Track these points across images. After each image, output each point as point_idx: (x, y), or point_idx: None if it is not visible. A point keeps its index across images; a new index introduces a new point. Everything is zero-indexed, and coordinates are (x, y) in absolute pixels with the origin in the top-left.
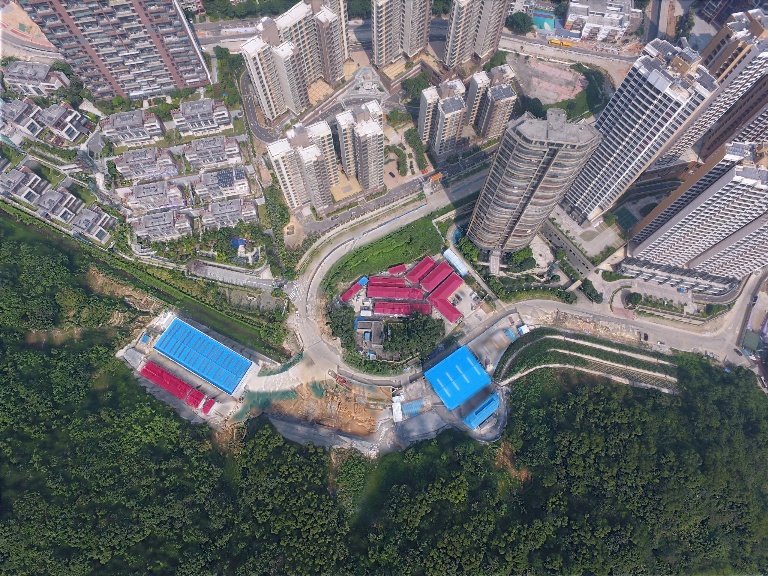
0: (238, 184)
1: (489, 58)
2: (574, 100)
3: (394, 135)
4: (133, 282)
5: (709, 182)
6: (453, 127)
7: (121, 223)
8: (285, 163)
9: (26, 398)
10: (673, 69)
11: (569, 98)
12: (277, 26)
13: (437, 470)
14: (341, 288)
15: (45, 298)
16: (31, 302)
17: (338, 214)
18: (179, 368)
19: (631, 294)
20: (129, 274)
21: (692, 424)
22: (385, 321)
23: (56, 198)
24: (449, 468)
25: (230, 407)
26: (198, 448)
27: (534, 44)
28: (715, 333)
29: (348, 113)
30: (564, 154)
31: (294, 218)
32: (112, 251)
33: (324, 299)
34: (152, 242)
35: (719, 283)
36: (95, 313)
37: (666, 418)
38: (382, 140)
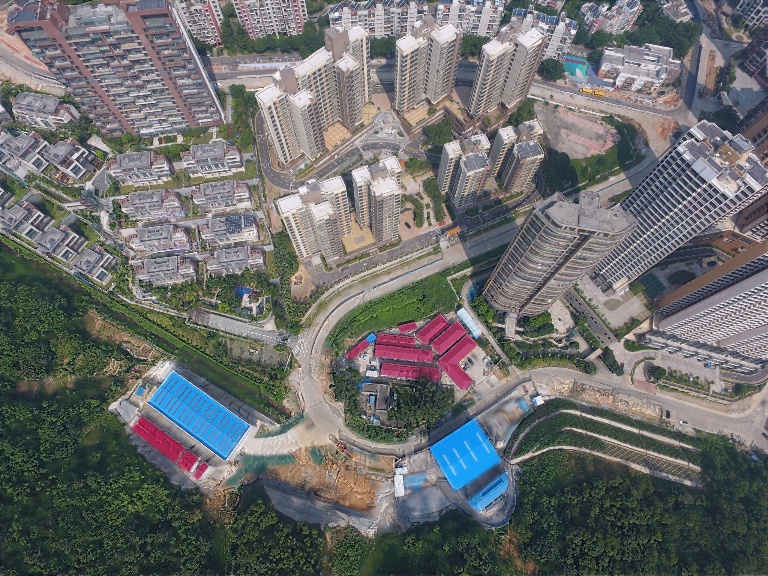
0: (246, 230)
1: (516, 107)
2: (604, 156)
3: (412, 183)
4: (132, 327)
5: (750, 270)
6: (475, 183)
7: (124, 264)
8: (296, 219)
9: (11, 456)
10: (721, 157)
11: (599, 153)
12: (295, 74)
13: (438, 563)
14: (347, 344)
15: (39, 345)
16: (24, 349)
17: (349, 265)
18: (173, 424)
19: (654, 368)
20: (129, 318)
21: (717, 528)
22: (392, 383)
23: (58, 237)
24: (451, 560)
25: (224, 471)
26: (187, 519)
27: (564, 92)
28: (742, 414)
29: (365, 169)
30: (595, 241)
31: (303, 267)
32: (112, 294)
33: (329, 356)
34: (154, 286)
35: (750, 362)
36: (90, 361)
37: (689, 521)
38: (399, 199)
